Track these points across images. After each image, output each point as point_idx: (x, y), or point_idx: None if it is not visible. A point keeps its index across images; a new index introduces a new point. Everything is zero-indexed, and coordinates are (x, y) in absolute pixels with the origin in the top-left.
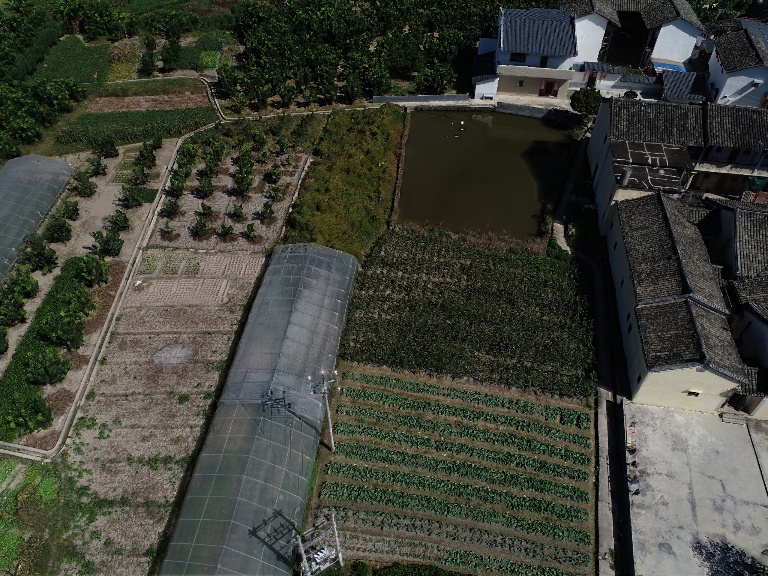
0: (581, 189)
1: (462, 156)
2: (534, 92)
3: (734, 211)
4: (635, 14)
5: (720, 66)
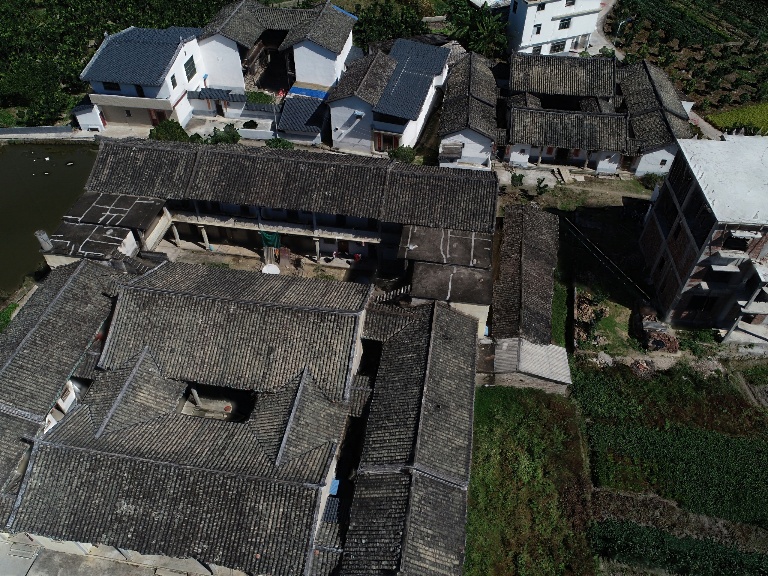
0: None
1: (12, 200)
2: (146, 122)
3: None
4: (287, 33)
5: None
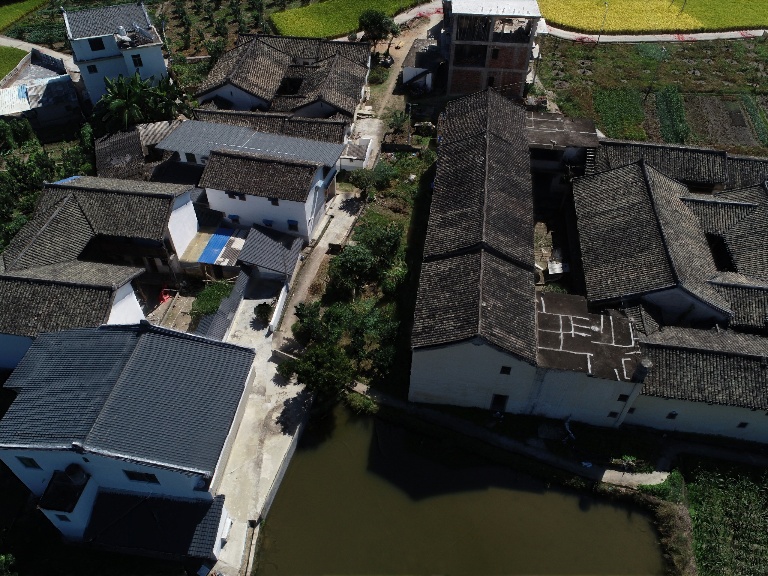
0: (519, 429)
1: None
2: None
3: (679, 287)
4: None
5: (267, 202)
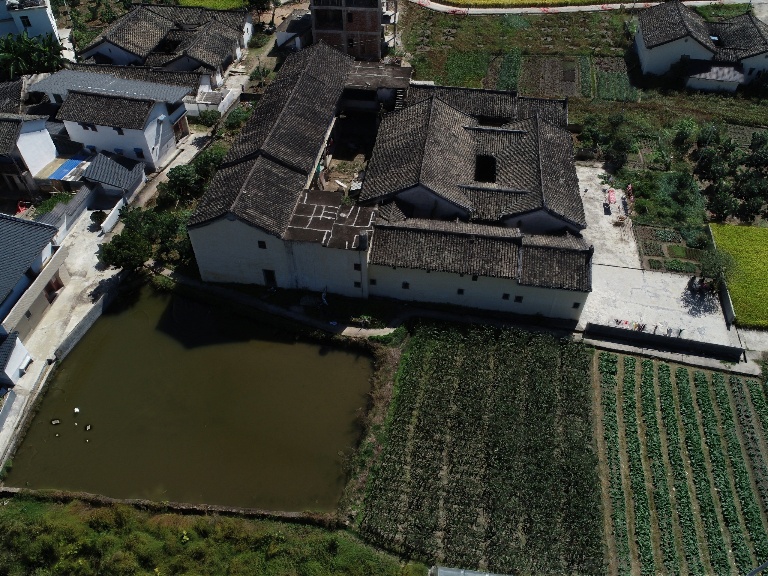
0: (285, 299)
1: (171, 418)
2: (44, 306)
3: (420, 185)
4: None
5: (113, 131)
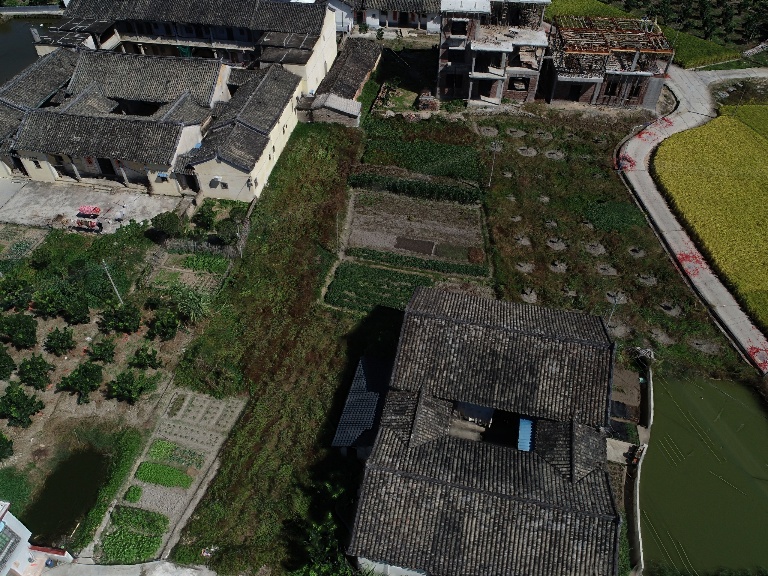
0: None
1: (16, 45)
2: None
3: None
4: None
5: None
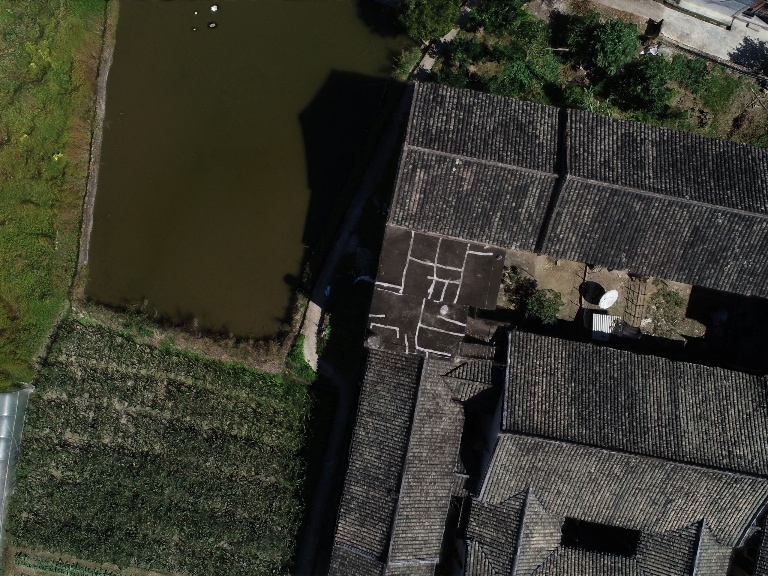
0: (367, 228)
1: (202, 115)
2: None
3: None
4: None
5: None
